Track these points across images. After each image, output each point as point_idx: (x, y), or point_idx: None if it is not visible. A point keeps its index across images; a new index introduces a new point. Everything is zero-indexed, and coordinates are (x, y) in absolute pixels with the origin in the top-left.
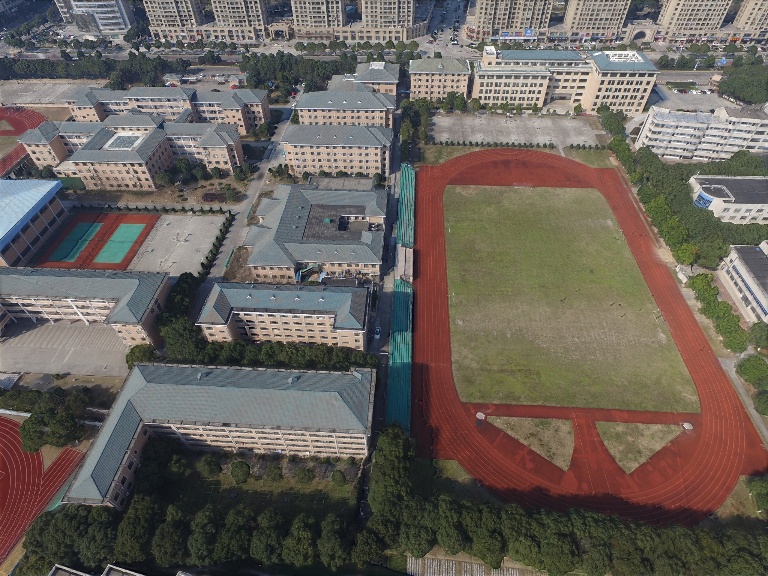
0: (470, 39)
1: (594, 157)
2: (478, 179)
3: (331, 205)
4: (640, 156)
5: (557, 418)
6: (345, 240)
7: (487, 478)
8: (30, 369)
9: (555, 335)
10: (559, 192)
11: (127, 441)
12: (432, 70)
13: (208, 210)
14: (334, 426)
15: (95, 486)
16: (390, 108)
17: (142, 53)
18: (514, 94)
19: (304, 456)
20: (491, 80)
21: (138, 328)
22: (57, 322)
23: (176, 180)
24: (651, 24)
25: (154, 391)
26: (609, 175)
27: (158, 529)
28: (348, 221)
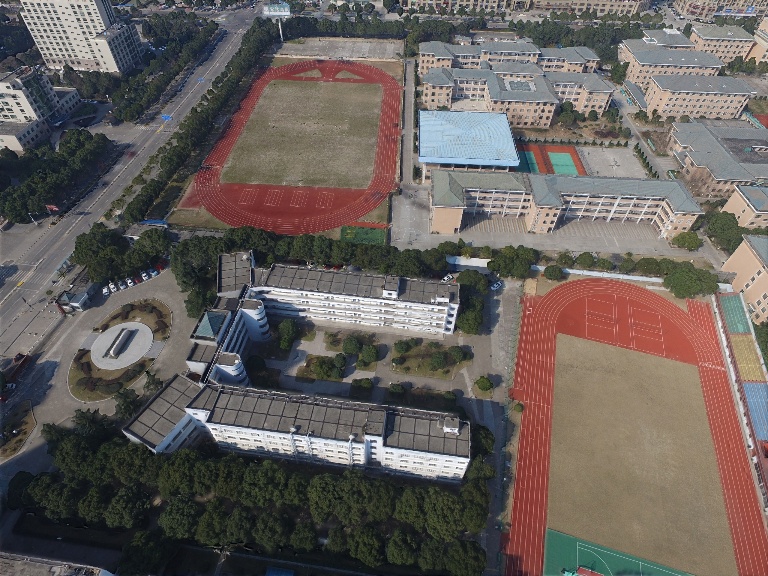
0: (691, 15)
1: None
2: None
3: (736, 139)
4: None
5: None
6: None
7: None
8: (597, 250)
9: None
10: None
11: None
12: (723, 36)
13: None
14: None
15: None
16: (721, 65)
17: (417, 17)
18: None
19: None
20: None
21: (695, 217)
22: (581, 220)
23: (556, 121)
24: None
25: None
26: None
27: None
28: None
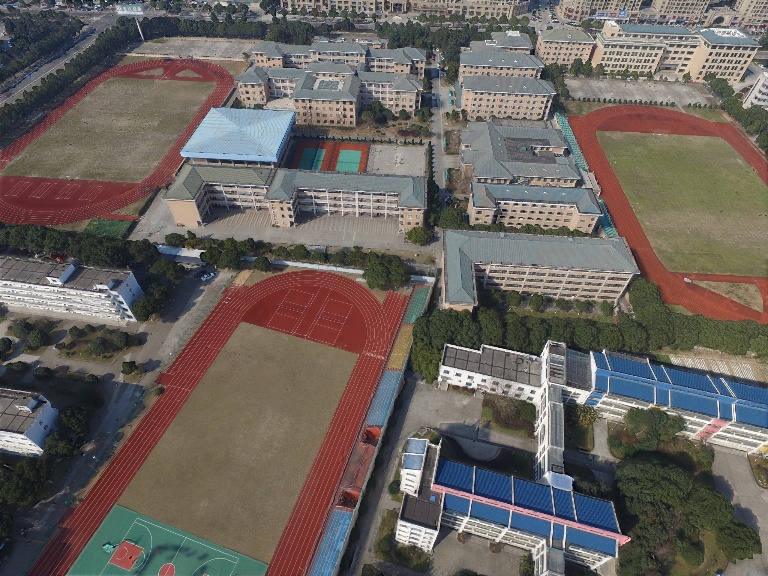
0: (568, 18)
1: (710, 114)
2: (621, 127)
3: (520, 138)
4: (753, 112)
5: (744, 283)
6: (544, 162)
7: (707, 315)
8: (330, 244)
9: (724, 233)
10: (691, 138)
11: (470, 272)
12: (562, 39)
13: (409, 142)
14: (613, 267)
15: (467, 294)
16: (541, 67)
17: (285, 18)
18: (631, 62)
19: (570, 299)
20: (614, 49)
21: (421, 212)
22: (332, 215)
23: None
24: (728, 11)
25: (477, 242)
26: (727, 127)
27: (511, 324)
28: (534, 151)
